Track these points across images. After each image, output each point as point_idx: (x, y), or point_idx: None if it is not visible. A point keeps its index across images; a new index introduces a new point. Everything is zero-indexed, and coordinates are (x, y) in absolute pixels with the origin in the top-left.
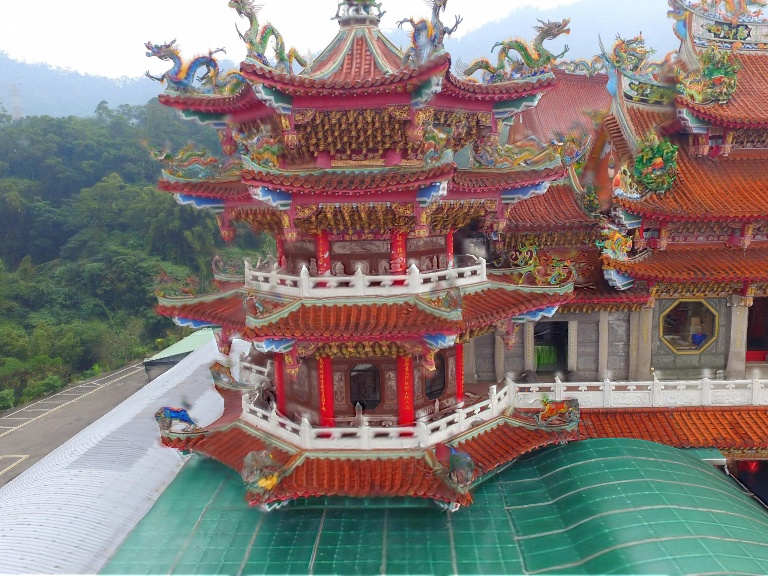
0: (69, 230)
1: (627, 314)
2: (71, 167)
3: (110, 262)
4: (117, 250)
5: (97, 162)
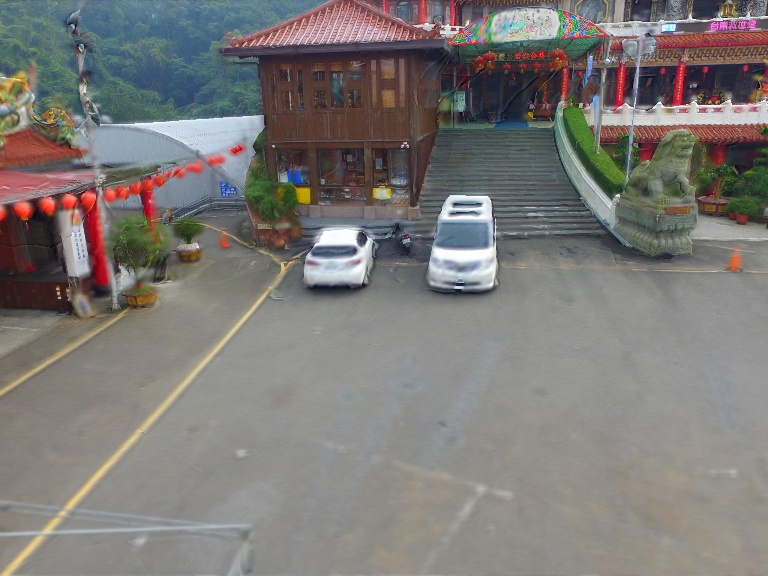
0: (200, 83)
1: (557, 5)
2: (199, 30)
3: (236, 102)
4: (242, 92)
5: (220, 24)
